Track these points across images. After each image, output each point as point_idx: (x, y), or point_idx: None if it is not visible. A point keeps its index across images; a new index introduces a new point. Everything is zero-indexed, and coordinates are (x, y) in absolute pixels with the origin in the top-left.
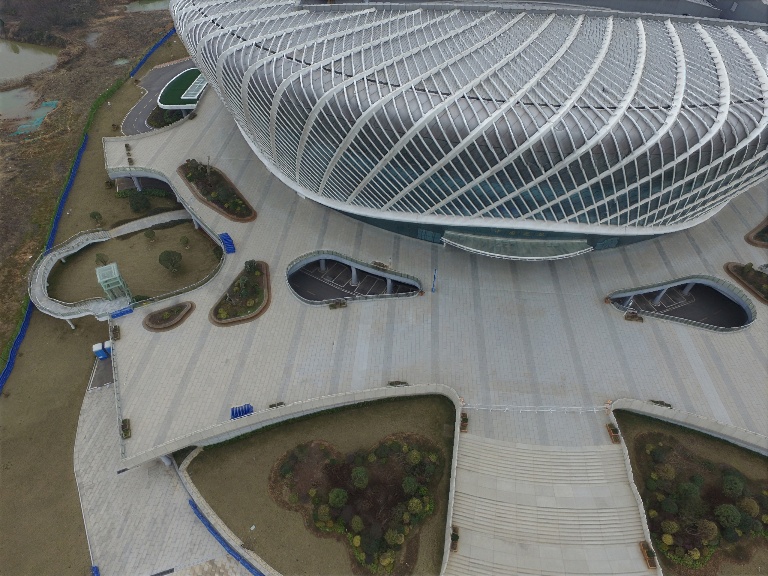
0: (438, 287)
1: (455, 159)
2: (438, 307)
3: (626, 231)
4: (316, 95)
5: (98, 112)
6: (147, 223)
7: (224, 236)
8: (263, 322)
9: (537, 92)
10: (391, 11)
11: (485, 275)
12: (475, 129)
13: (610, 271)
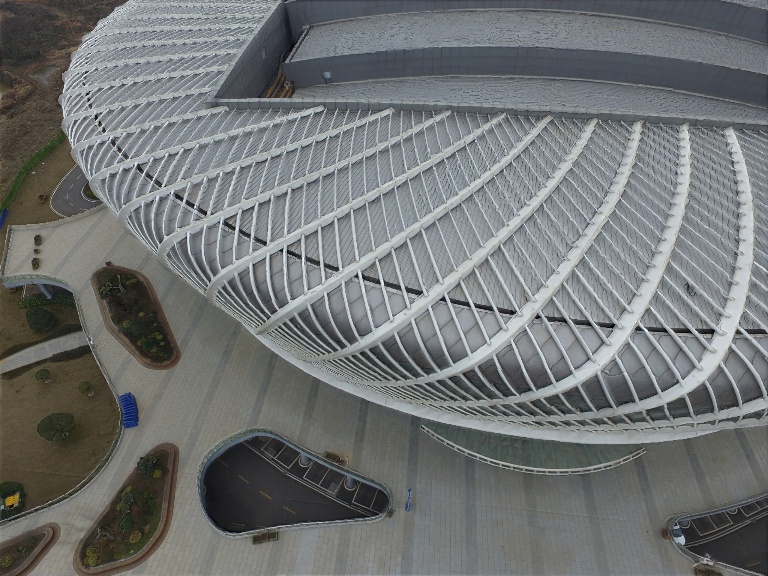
0: (416, 500)
1: (431, 383)
2: (413, 542)
3: (697, 433)
4: (210, 269)
5: (29, 176)
6: (48, 350)
7: (125, 400)
8: (151, 570)
9: (571, 295)
10: (347, 111)
11: (485, 476)
12: (462, 361)
13: (667, 471)
